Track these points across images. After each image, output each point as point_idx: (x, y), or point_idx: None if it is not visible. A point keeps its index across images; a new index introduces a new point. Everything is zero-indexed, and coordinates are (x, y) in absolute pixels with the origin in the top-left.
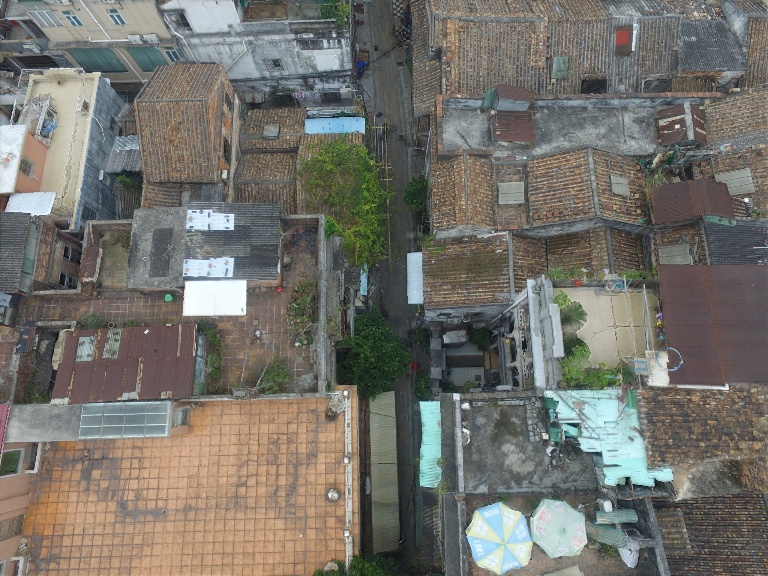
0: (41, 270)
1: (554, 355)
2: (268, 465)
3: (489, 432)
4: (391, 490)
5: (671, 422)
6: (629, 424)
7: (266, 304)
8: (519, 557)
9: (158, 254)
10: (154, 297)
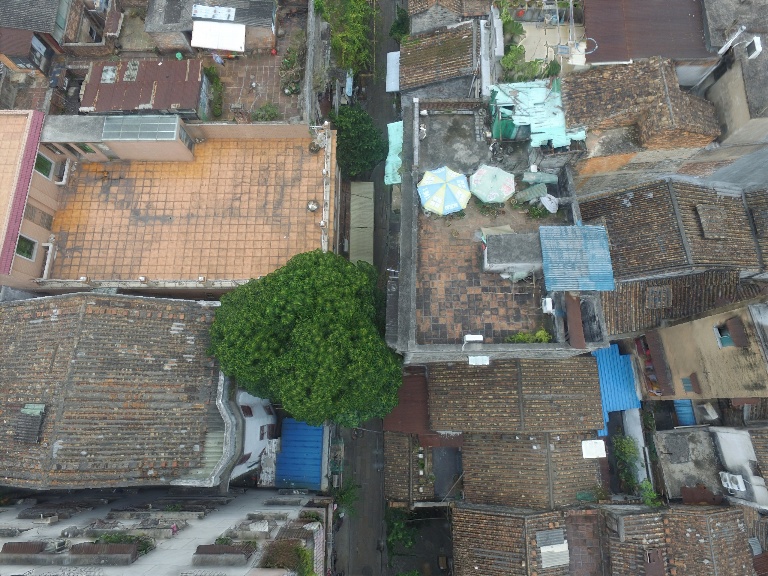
0: (71, 31)
1: (495, 54)
2: (259, 186)
3: (443, 135)
4: (367, 259)
5: (586, 96)
6: (554, 104)
7: (262, 64)
8: (459, 201)
9: (171, 6)
10: (166, 57)
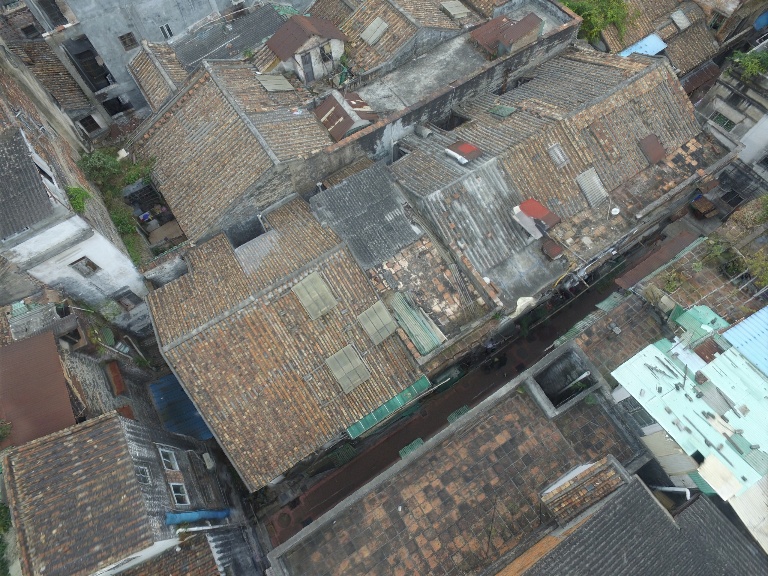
0: None
1: None
2: None
3: None
4: None
5: None
6: None
7: None
8: None
9: None
10: None
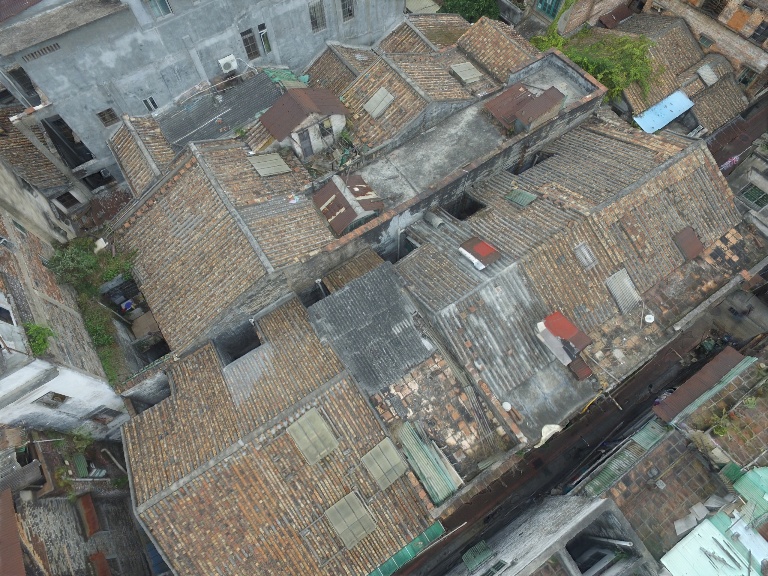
0: None
1: None
2: None
3: None
4: None
5: None
6: None
7: None
8: None
9: None
10: None
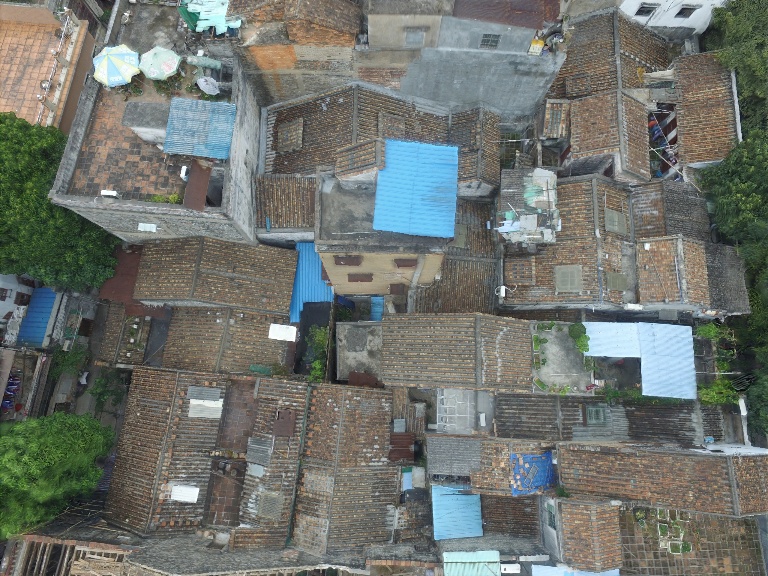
0: None
1: None
2: (4, 63)
3: (148, 23)
4: None
5: None
6: None
7: None
8: (124, 74)
9: None
10: None
